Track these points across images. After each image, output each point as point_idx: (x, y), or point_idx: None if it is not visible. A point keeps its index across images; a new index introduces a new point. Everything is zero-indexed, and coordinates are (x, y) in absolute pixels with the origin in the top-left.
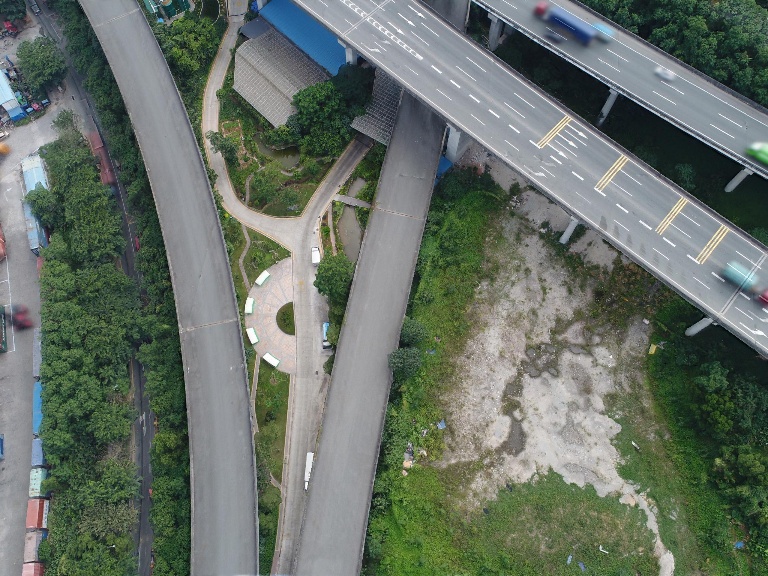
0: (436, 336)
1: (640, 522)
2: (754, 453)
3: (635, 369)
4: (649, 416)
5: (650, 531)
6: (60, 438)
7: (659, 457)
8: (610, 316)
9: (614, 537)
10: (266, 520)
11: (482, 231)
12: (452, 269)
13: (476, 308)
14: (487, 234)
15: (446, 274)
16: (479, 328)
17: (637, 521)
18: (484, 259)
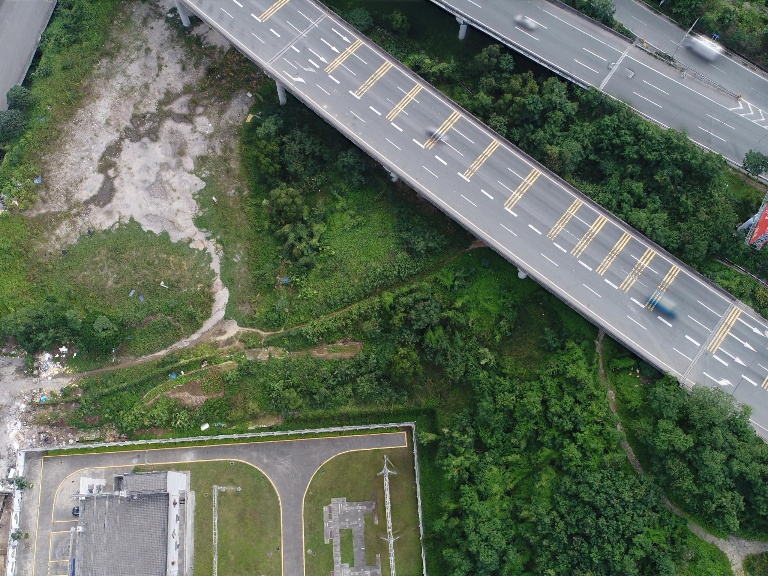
0: (48, 105)
1: (205, 263)
2: (308, 199)
3: (230, 135)
4: (233, 175)
5: (212, 271)
6: None
7: (234, 209)
8: (216, 90)
9: (177, 275)
10: None
11: (111, 15)
12: (75, 47)
13: (92, 82)
14: (116, 18)
15: (69, 52)
16: (91, 99)
17: (202, 262)
18: (108, 39)
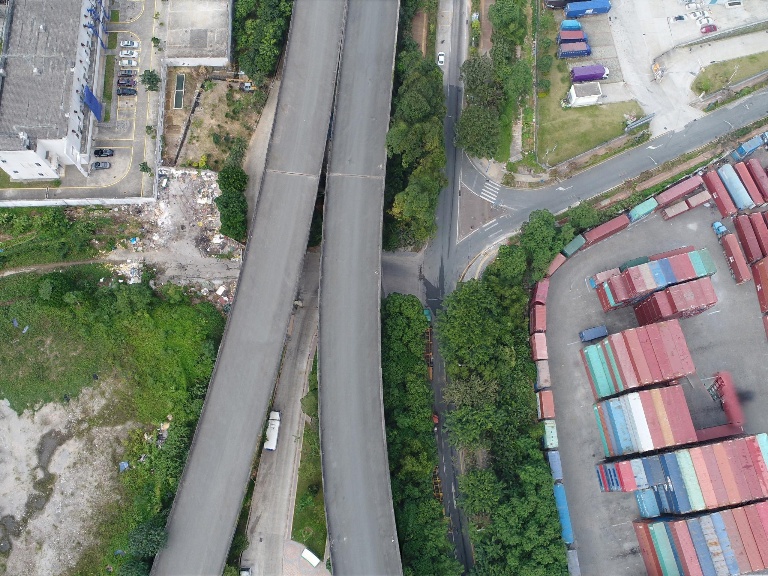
0: (111, 572)
1: None
2: None
3: None
4: None
5: None
6: (531, 474)
7: None
8: None
9: None
10: (314, 380)
11: None
12: None
13: None
14: None
15: None
16: None
17: None
18: None
